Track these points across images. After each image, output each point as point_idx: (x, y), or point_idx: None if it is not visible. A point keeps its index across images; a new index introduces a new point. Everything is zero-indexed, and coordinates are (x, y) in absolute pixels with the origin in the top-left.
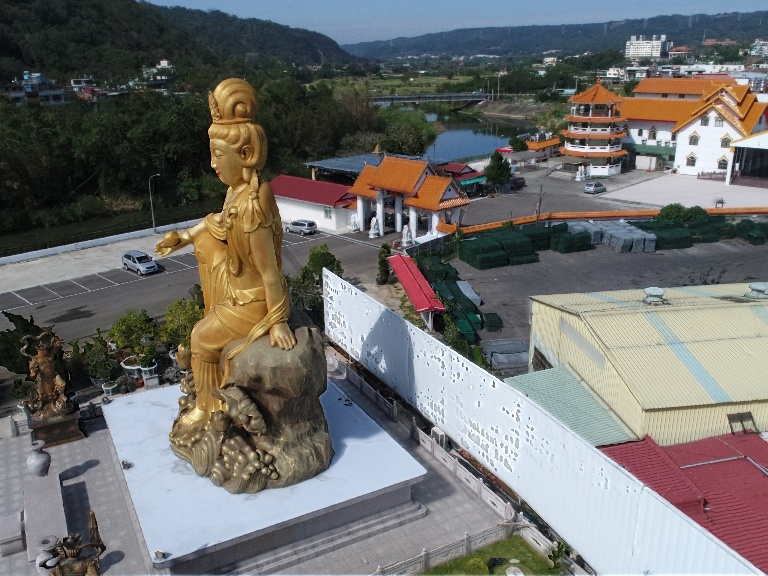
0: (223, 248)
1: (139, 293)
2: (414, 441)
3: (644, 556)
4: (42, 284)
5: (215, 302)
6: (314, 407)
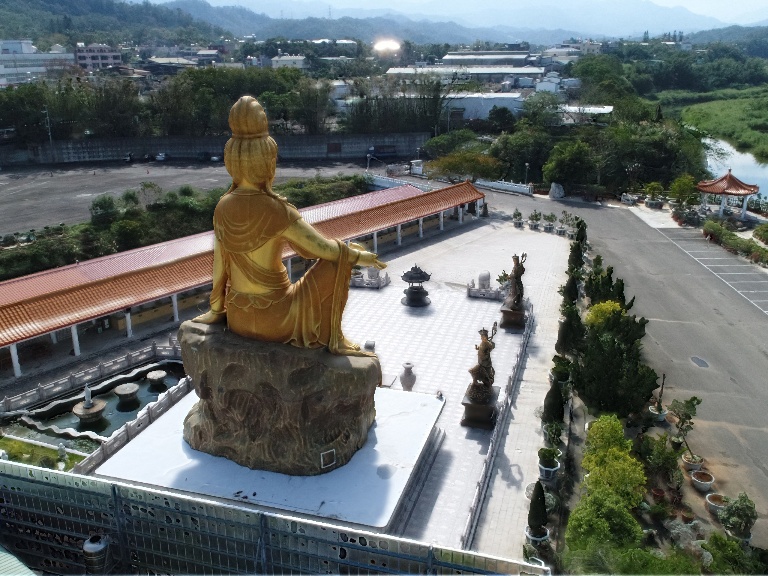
0: None
1: None
2: None
3: None
4: None
5: None
6: None
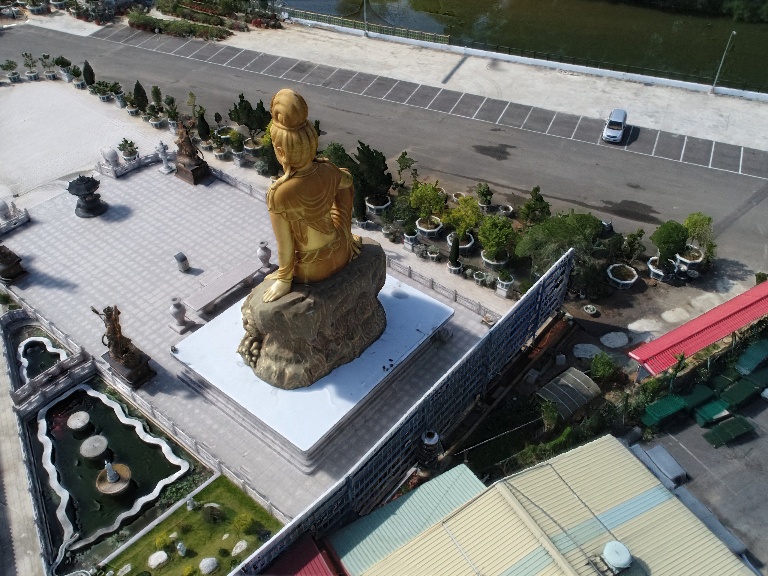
0: None
1: (566, 158)
2: None
3: None
4: (536, 106)
5: None
6: (302, 348)
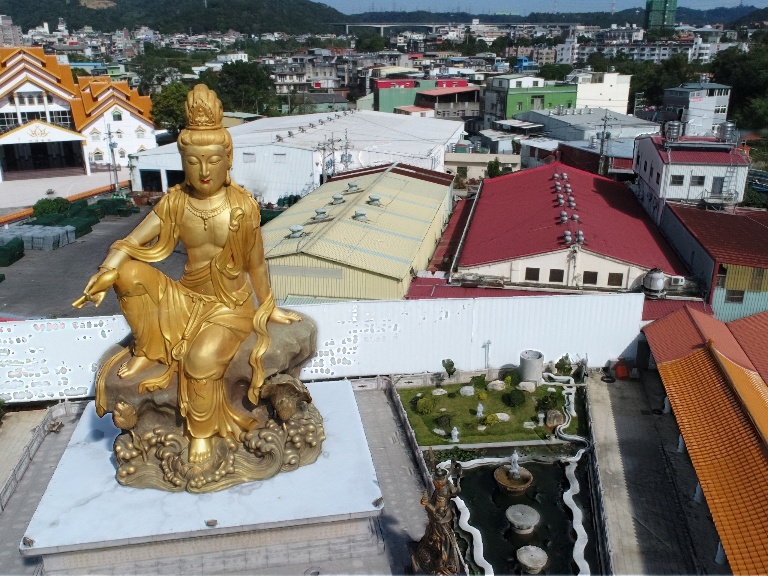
0: (157, 271)
1: None
2: None
3: (481, 336)
4: None
5: (171, 328)
6: None
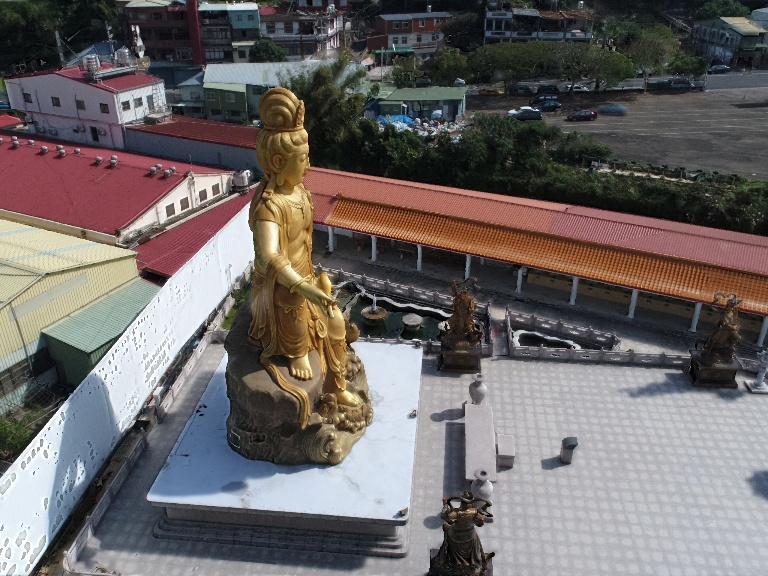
0: None
1: None
2: (166, 418)
3: None
4: None
5: None
6: None
